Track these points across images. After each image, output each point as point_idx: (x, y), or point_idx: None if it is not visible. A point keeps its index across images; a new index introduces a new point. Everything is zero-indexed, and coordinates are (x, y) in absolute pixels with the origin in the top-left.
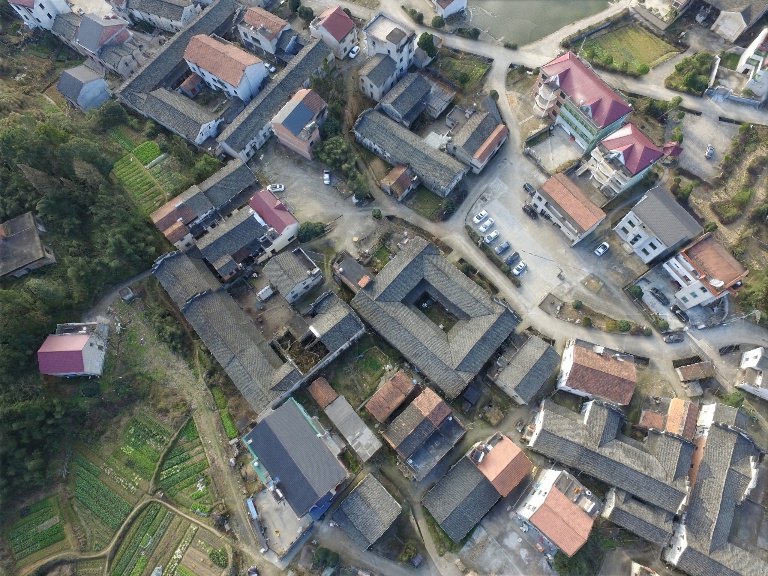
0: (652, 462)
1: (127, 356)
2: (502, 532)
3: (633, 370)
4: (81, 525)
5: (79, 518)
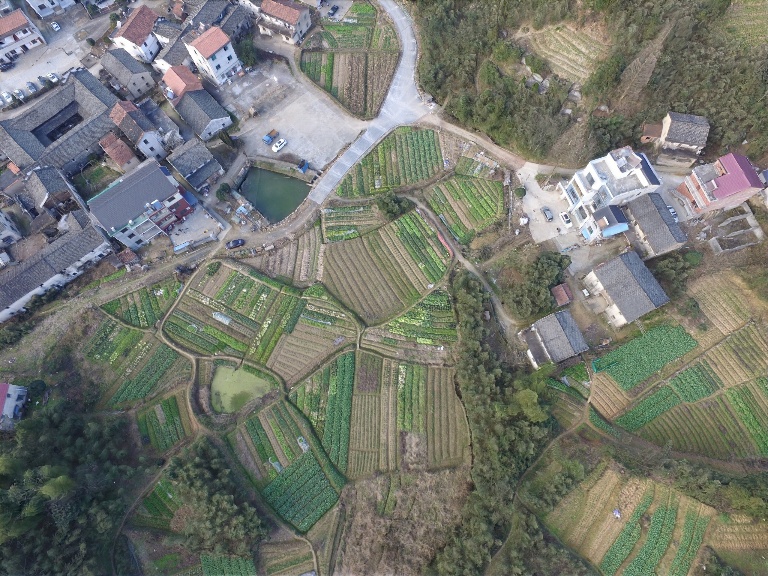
0: (198, 8)
1: (21, 370)
2: (231, 95)
3: (138, 8)
4: (169, 386)
5: (162, 390)
